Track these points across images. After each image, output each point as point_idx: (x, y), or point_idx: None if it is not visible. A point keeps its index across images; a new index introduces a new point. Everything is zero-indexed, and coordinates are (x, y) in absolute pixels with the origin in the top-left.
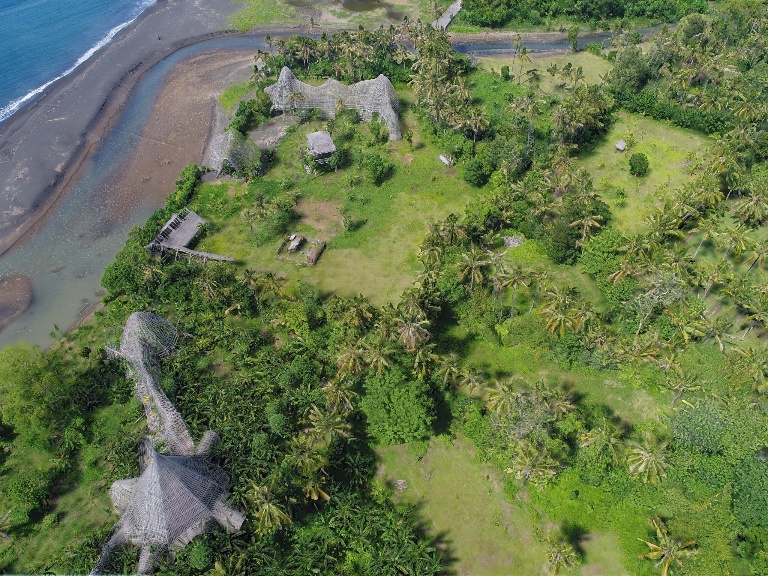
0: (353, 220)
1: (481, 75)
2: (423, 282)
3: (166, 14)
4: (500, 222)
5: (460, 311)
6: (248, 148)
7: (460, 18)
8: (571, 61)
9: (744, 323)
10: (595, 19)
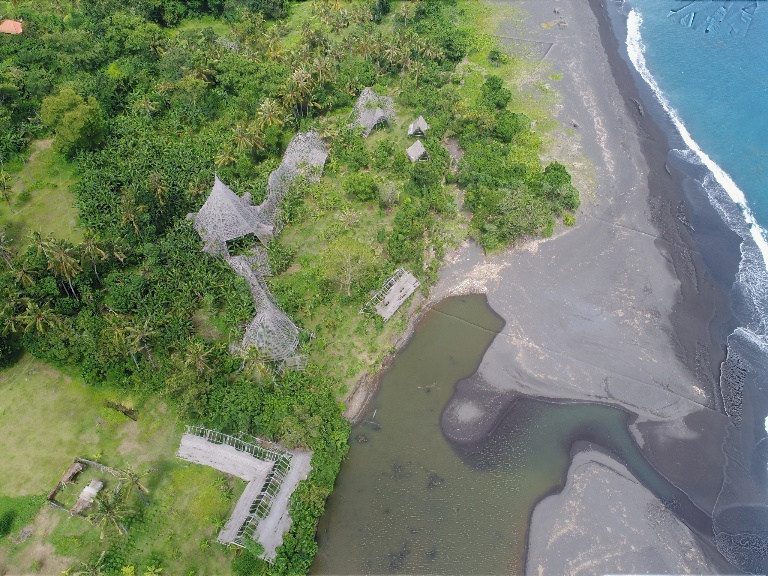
0: None
1: None
2: None
3: None
4: None
5: None
6: None
7: None
8: None
9: None
10: None
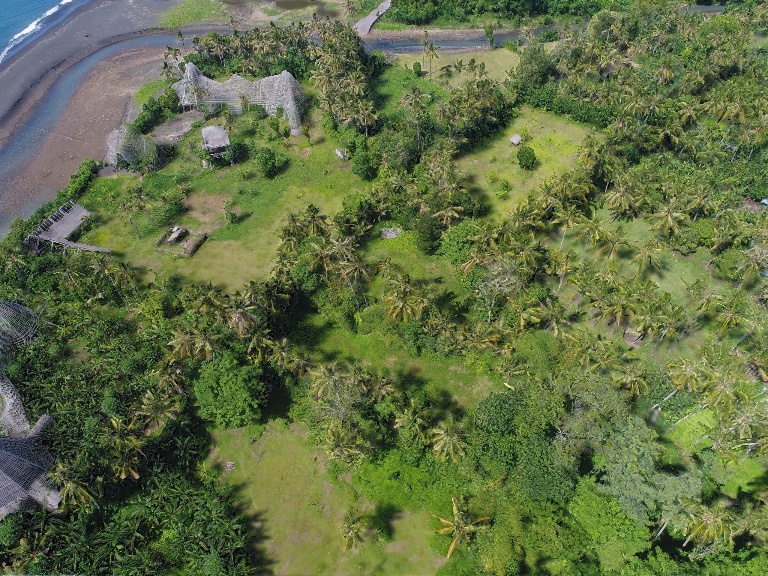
0: (239, 213)
1: (395, 71)
2: (277, 271)
3: (98, 12)
4: (376, 214)
5: (317, 300)
6: (143, 142)
7: (386, 15)
8: (487, 57)
9: (598, 311)
10: (519, 16)
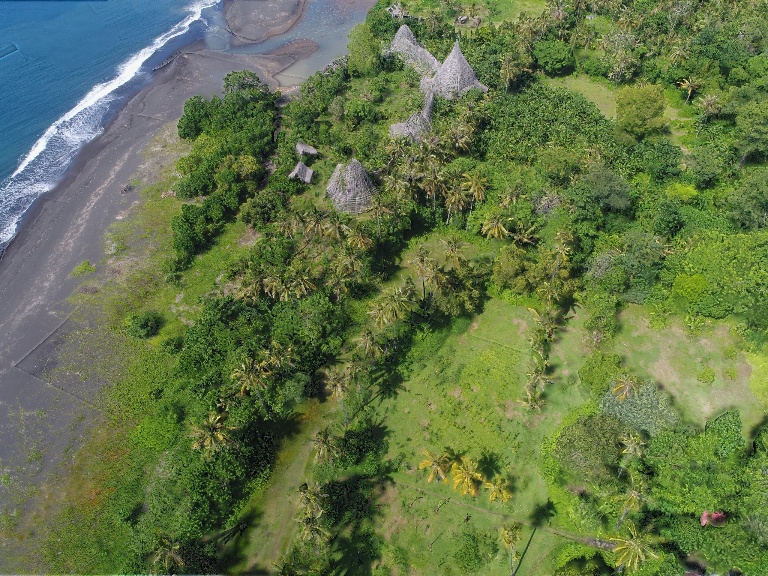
0: None
1: None
2: None
3: None
4: None
5: None
6: None
7: None
8: None
9: None
10: None
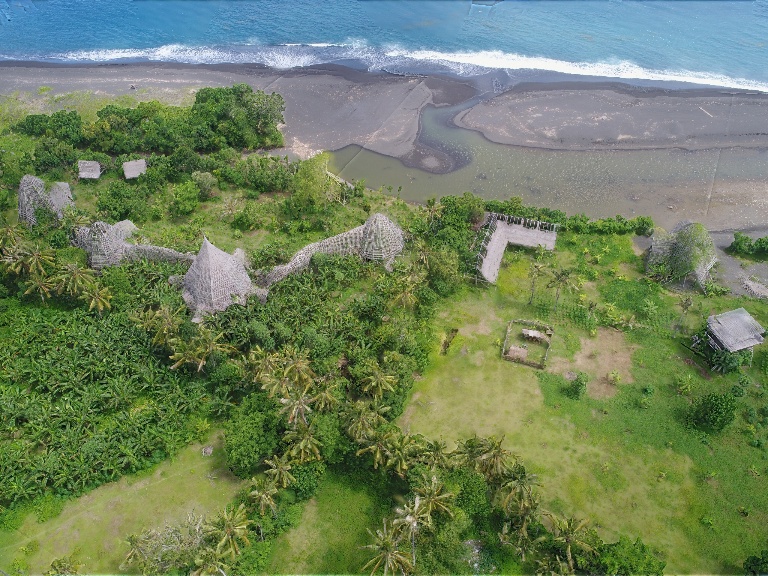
0: (602, 396)
1: None
2: None
3: None
4: None
5: None
6: (687, 254)
7: None
8: None
9: None
10: None
